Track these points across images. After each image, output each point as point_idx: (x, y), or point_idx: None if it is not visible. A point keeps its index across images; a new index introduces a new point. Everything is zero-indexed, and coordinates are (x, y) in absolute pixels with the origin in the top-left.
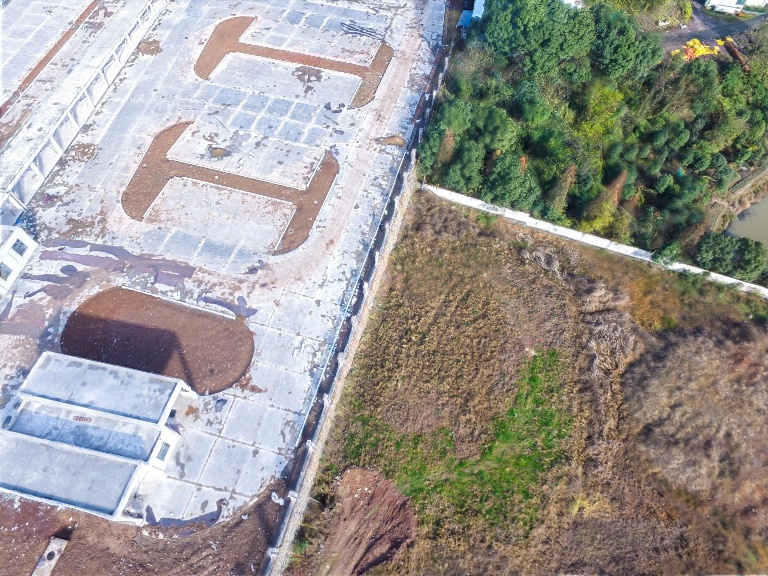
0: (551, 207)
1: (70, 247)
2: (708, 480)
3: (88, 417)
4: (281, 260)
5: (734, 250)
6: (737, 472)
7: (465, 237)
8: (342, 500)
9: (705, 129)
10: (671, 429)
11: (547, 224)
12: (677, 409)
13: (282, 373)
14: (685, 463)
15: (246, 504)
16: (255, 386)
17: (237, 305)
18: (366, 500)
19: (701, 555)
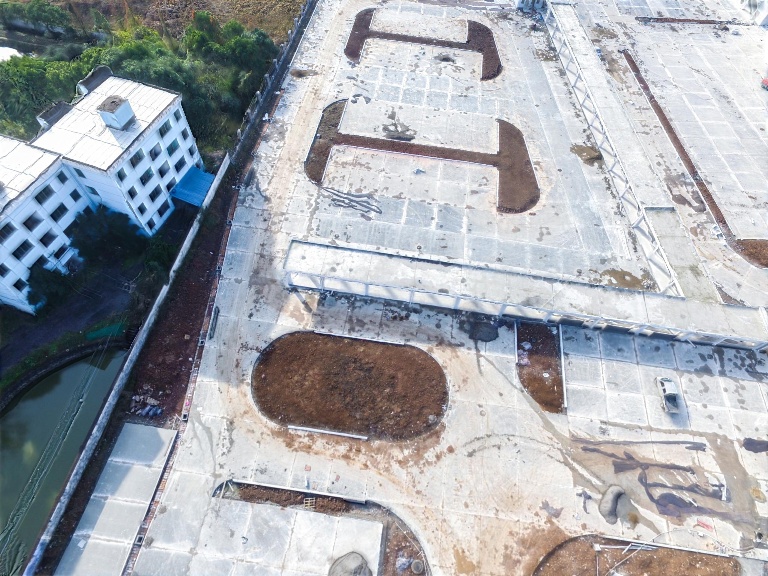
0: None
1: (498, 8)
2: None
3: None
4: (369, 6)
5: None
6: None
7: None
8: None
9: None
10: None
11: None
12: None
13: None
14: None
15: None
16: None
17: None
18: None
19: None
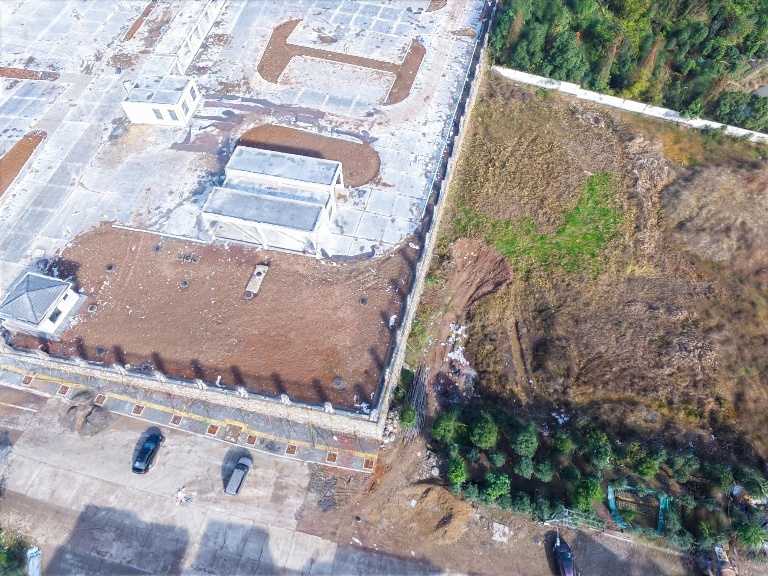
0: (598, 78)
1: (226, 99)
2: (728, 253)
3: (275, 187)
4: (391, 108)
5: (746, 102)
6: (750, 245)
7: (529, 102)
8: (455, 260)
9: (721, 29)
10: (699, 222)
11: (594, 94)
12: (704, 208)
13: (404, 176)
14: (711, 242)
15: (392, 248)
16: (385, 183)
17: (362, 135)
18: (473, 260)
19: (724, 298)
